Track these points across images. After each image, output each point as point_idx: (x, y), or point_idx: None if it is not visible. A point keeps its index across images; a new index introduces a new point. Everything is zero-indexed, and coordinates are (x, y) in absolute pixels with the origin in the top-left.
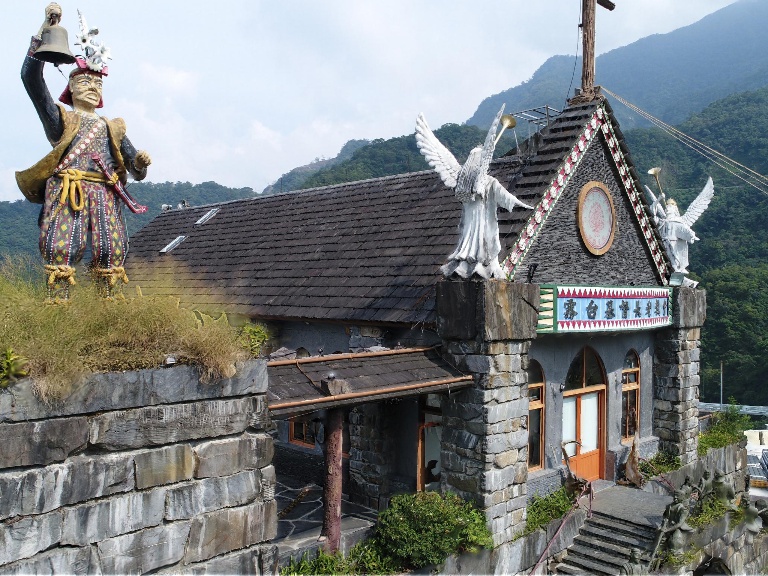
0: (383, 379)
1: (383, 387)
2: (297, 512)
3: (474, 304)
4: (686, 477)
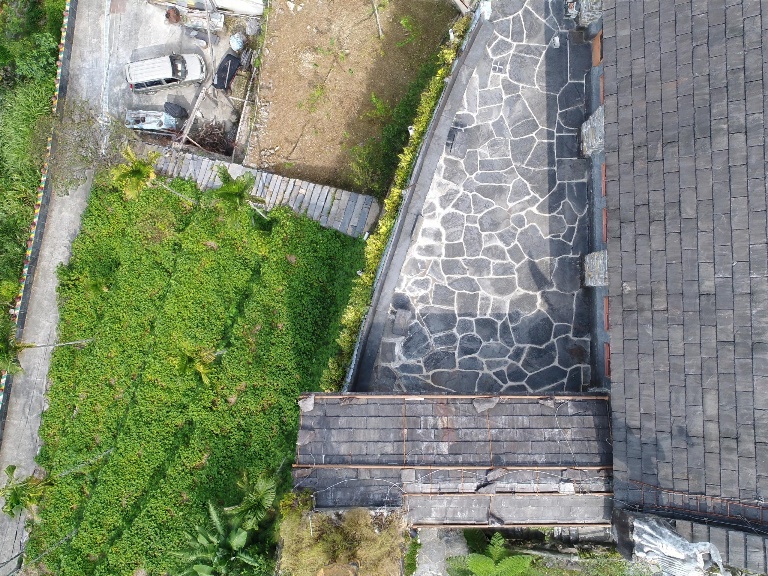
0: (543, 512)
1: (535, 518)
2: (543, 380)
3: (625, 546)
4: (734, 575)
